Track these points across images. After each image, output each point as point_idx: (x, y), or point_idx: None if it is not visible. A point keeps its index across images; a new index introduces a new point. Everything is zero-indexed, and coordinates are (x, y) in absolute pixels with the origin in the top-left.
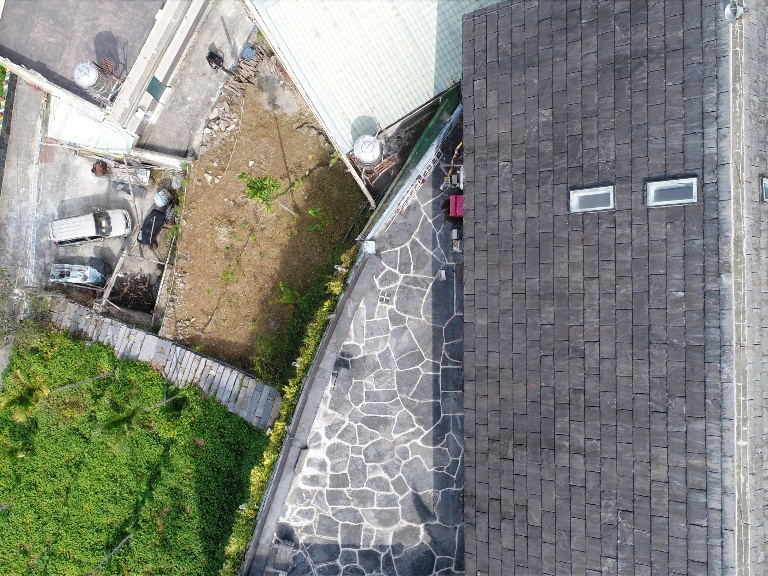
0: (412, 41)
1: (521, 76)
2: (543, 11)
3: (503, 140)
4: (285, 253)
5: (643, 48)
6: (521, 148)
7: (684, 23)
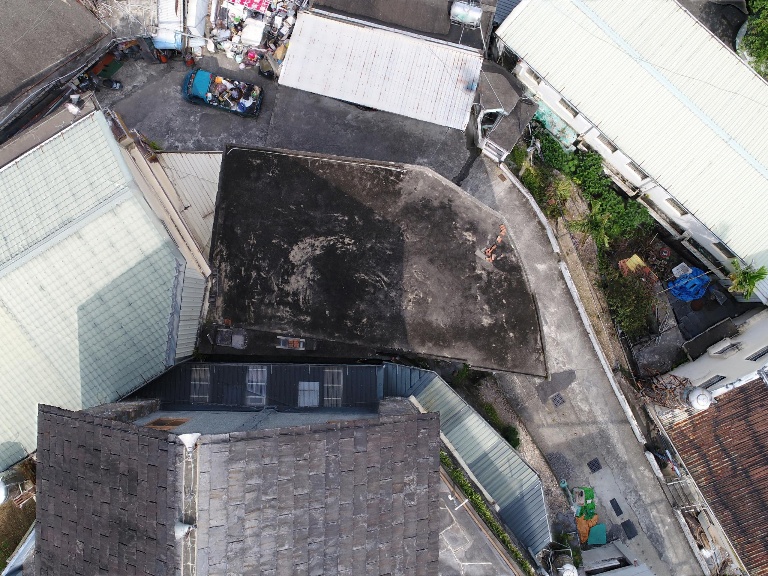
0: (54, 369)
1: (67, 495)
2: (80, 437)
3: (56, 554)
4: (12, 504)
5: (134, 522)
6: (65, 571)
7: (157, 515)
